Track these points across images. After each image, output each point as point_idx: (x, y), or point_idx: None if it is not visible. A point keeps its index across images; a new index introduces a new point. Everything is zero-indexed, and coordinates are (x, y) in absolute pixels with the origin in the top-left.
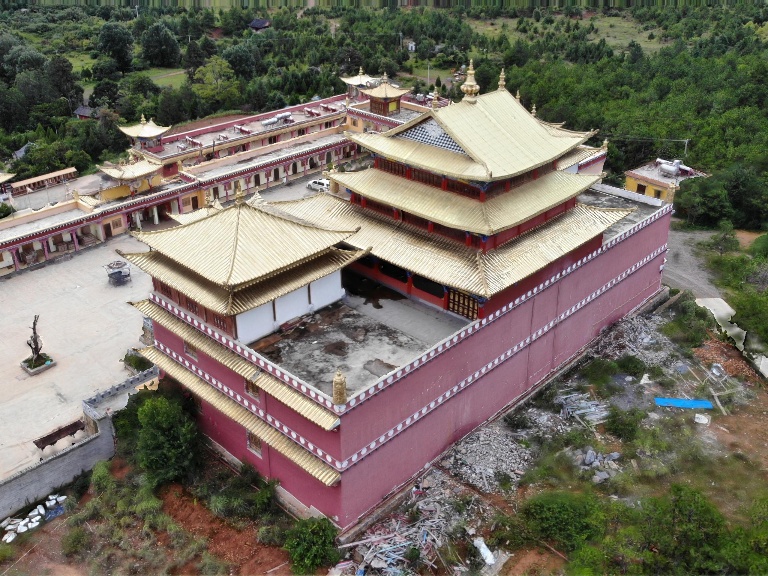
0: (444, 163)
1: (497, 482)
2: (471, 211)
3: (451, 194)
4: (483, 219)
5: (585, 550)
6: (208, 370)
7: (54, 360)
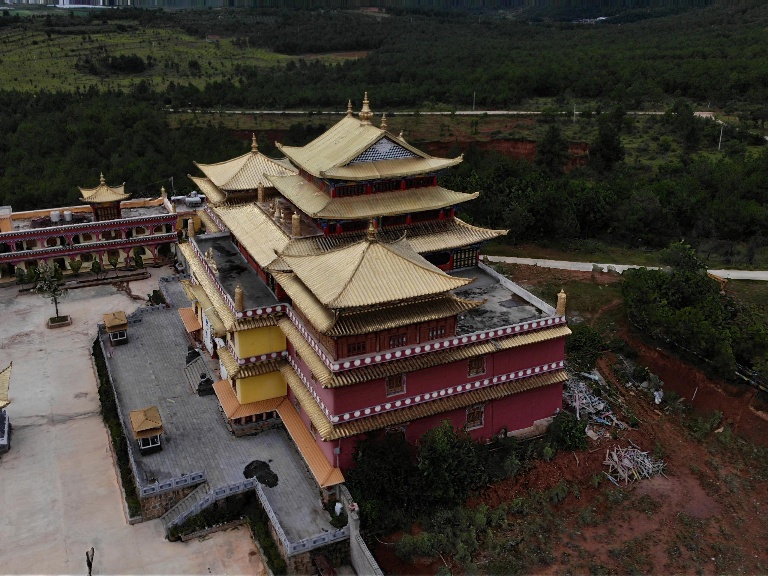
0: (408, 167)
1: None
2: (439, 193)
3: (411, 190)
4: (455, 193)
5: (659, 312)
6: (420, 391)
7: None
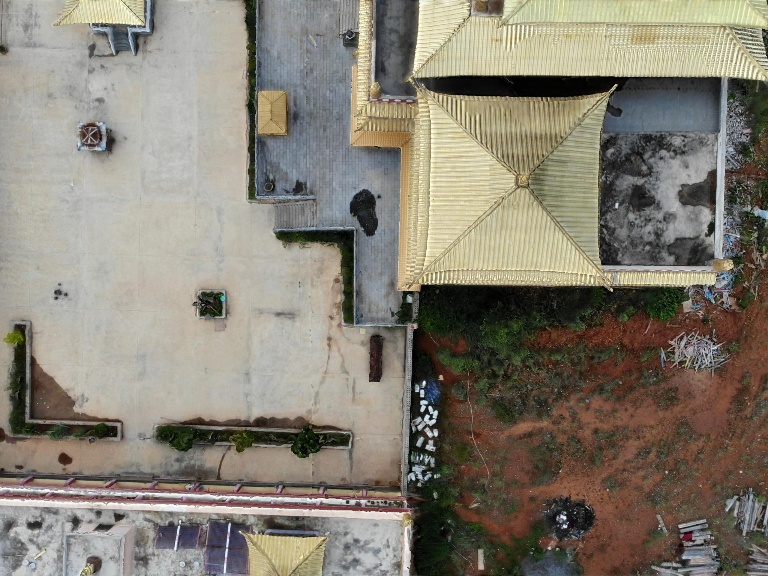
0: None
1: (741, 155)
2: None
3: None
4: (748, 6)
5: None
6: None
7: (220, 290)
